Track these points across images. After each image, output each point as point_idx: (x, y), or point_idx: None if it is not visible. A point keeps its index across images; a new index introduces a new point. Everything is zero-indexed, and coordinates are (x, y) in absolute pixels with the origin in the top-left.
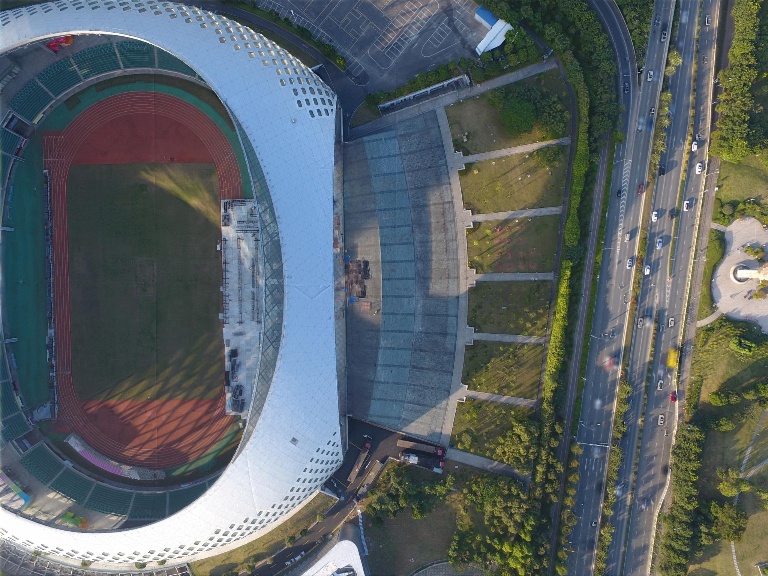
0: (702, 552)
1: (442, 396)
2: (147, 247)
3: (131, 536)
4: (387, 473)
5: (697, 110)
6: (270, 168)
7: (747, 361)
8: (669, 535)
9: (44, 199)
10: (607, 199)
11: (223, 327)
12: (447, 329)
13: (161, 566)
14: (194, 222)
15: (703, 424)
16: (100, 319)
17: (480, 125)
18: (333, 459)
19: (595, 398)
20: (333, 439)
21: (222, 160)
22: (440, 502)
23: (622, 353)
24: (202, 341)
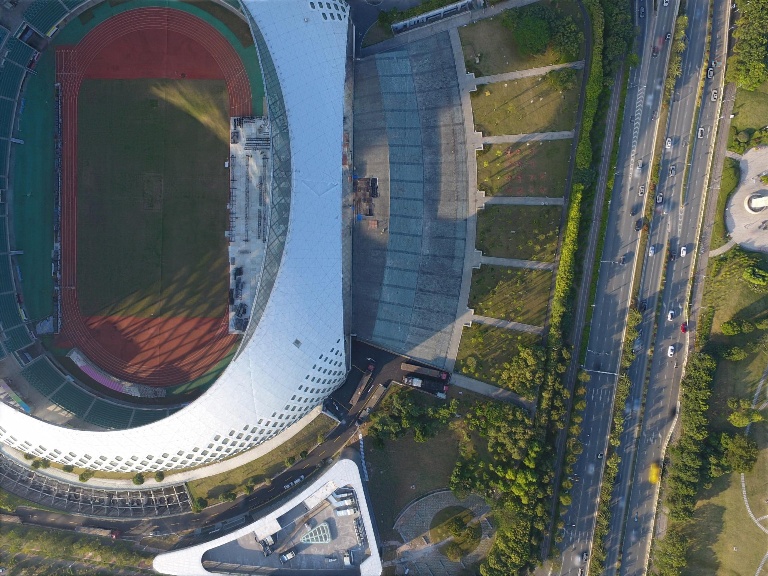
0: (711, 484)
1: (448, 320)
2: (155, 163)
3: (130, 436)
4: (390, 395)
5: (714, 36)
6: (281, 62)
7: (760, 292)
8: (677, 467)
9: (55, 112)
10: (620, 124)
11: (229, 245)
12: (454, 252)
13: (159, 485)
14: (203, 139)
15: (714, 353)
16: (106, 234)
17: (493, 47)
18: (336, 370)
19: (604, 327)
20: (336, 347)
21: (233, 77)
22: (443, 427)
23: (632, 281)
24: (207, 258)
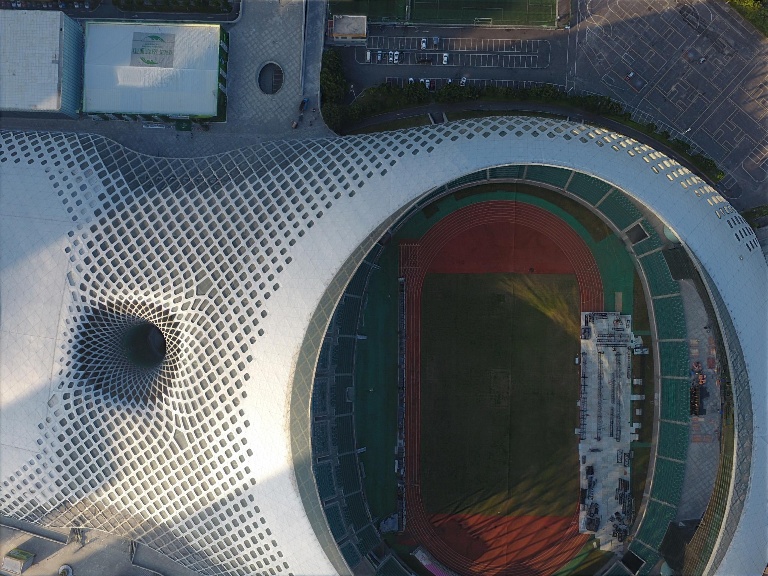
0: None
1: None
2: (502, 358)
3: None
4: None
5: None
6: (735, 312)
7: None
8: None
9: (400, 308)
10: None
11: (579, 442)
12: None
13: None
14: (552, 334)
15: None
16: (451, 430)
17: None
18: None
19: None
20: None
21: (584, 272)
22: None
23: None
24: (557, 456)
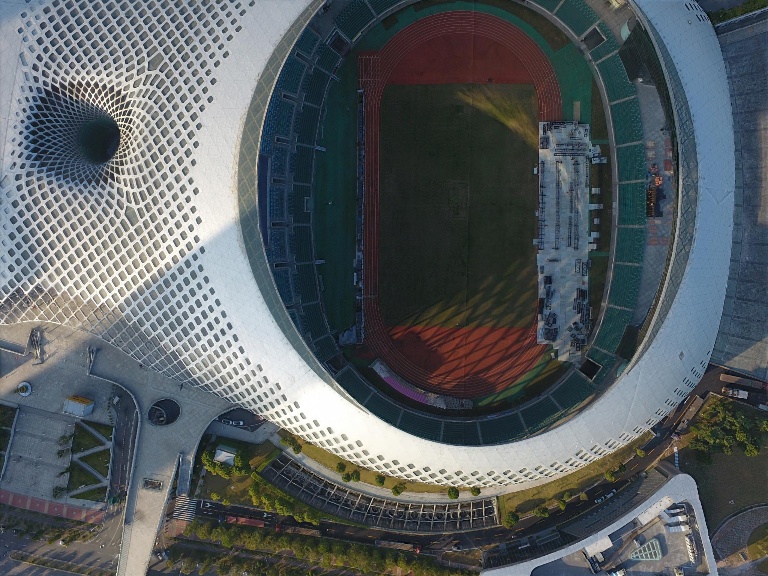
0: None
1: None
2: (461, 169)
3: (502, 451)
4: (714, 408)
5: None
6: (681, 66)
7: None
8: None
9: (359, 119)
10: None
11: (537, 253)
12: None
13: (469, 498)
14: (511, 144)
15: None
16: (410, 242)
17: None
18: (695, 382)
19: None
20: (705, 359)
21: (542, 81)
22: None
23: None
24: (515, 267)
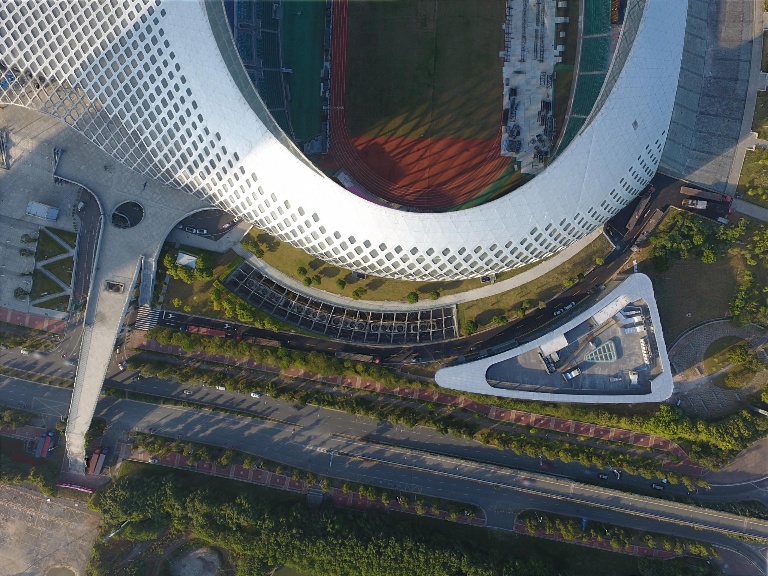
0: None
1: (729, 144)
2: None
3: (456, 220)
4: (673, 217)
5: None
6: None
7: None
8: None
9: None
10: None
11: (503, 66)
12: (738, 74)
13: (428, 306)
14: None
15: None
16: (377, 54)
17: None
18: (651, 168)
19: None
20: (660, 139)
21: None
22: None
23: None
24: (481, 79)
